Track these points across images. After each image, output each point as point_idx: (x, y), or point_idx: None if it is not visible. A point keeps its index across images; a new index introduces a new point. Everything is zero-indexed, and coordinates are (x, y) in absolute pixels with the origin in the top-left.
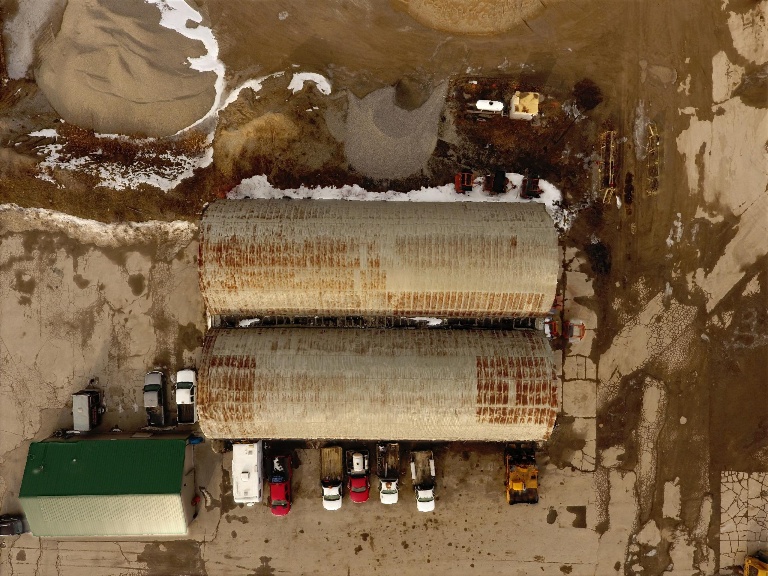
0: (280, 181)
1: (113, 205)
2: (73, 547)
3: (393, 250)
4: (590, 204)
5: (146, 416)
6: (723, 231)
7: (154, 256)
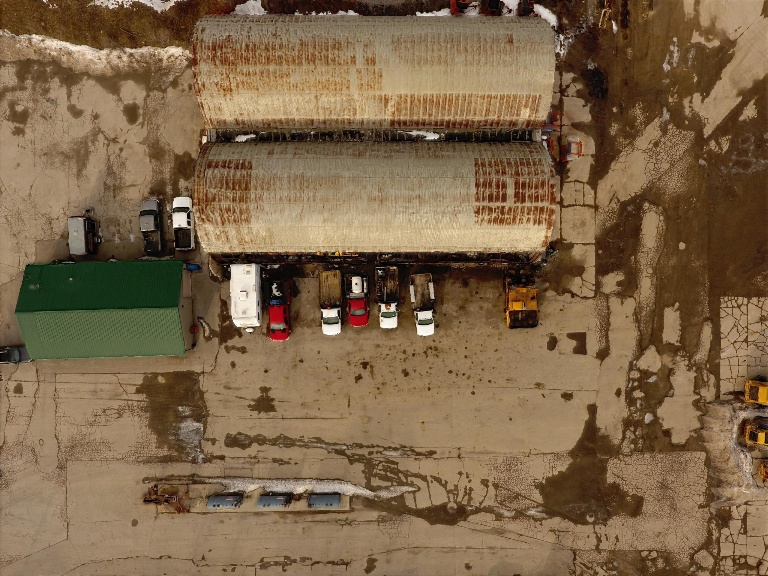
0: (274, 6)
1: (106, 26)
2: (71, 379)
3: (389, 48)
4: (586, 29)
5: (143, 245)
6: (719, 56)
7: (148, 85)
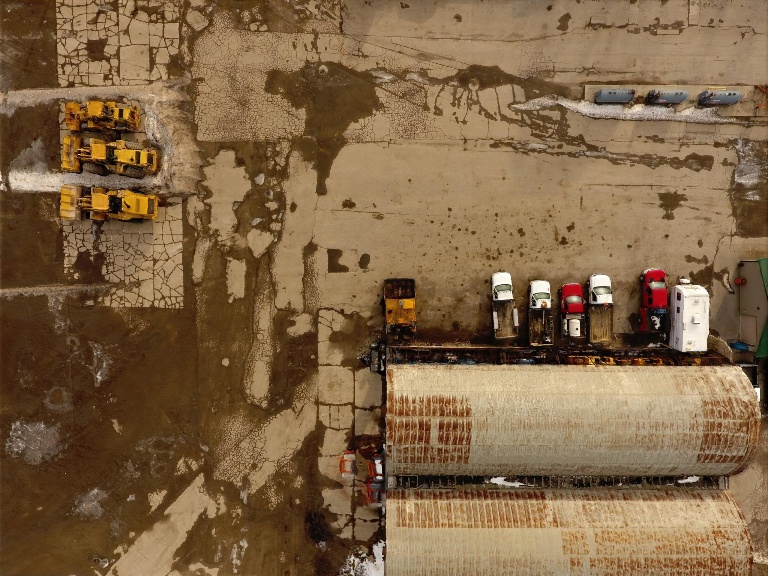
0: None
1: None
2: None
3: (556, 575)
4: None
5: None
6: (189, 555)
7: None
